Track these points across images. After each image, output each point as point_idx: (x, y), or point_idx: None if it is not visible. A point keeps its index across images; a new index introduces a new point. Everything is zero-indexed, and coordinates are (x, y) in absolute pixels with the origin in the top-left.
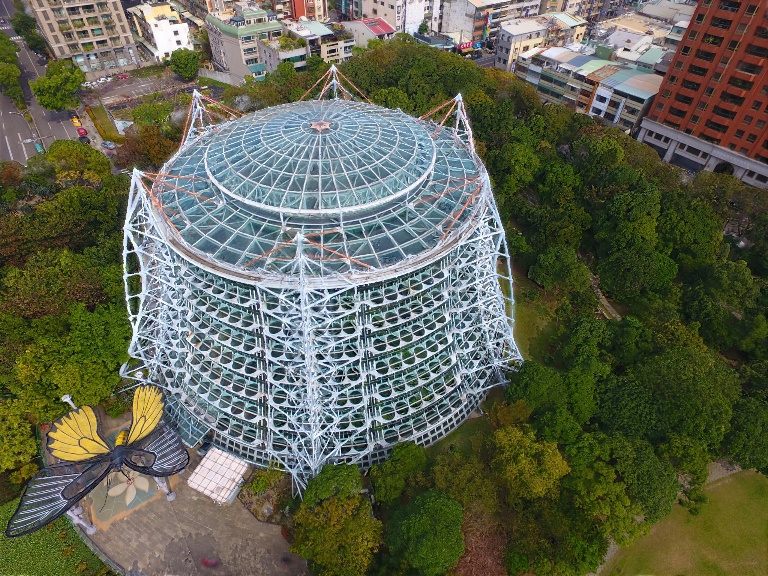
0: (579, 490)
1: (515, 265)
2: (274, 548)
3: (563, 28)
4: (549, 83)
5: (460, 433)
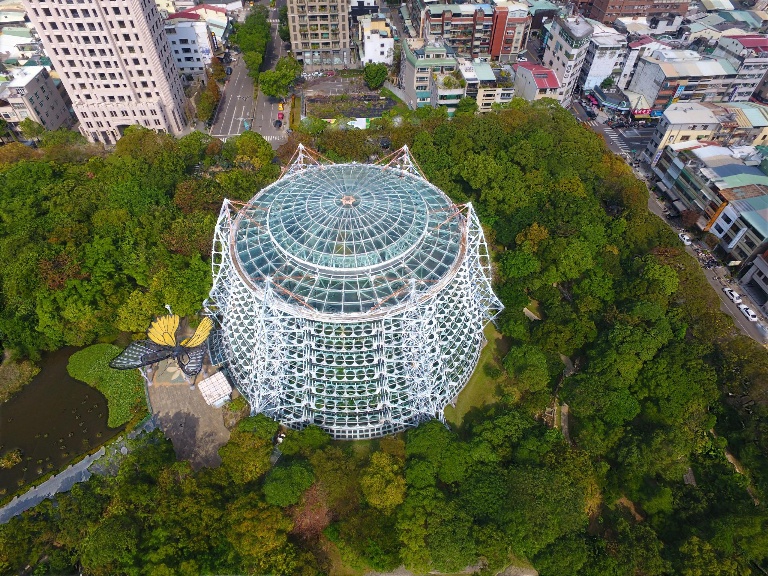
0: (398, 517)
1: (509, 345)
2: (223, 445)
3: (742, 126)
4: (686, 182)
5: (370, 443)
